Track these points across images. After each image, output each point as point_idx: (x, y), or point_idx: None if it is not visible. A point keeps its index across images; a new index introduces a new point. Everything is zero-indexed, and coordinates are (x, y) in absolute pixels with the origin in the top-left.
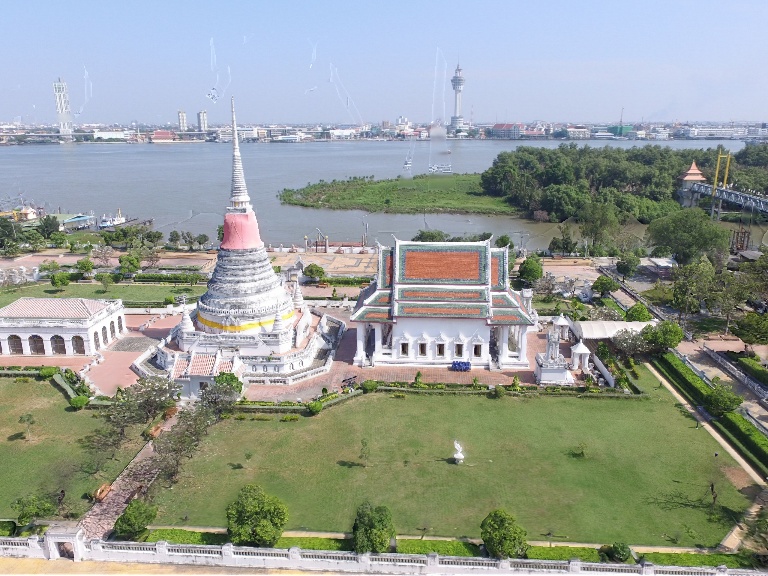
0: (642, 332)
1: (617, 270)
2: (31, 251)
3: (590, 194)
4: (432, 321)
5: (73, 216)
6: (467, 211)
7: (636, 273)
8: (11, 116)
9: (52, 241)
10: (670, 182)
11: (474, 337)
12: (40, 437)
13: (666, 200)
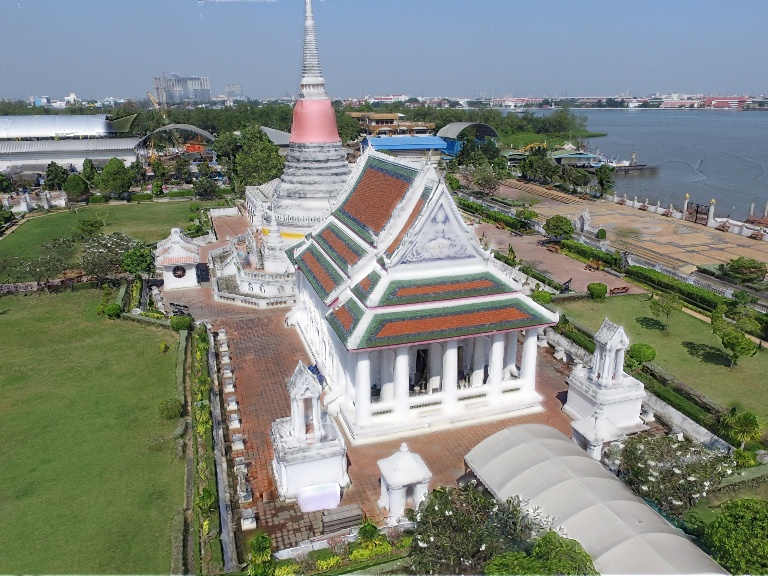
0: (533, 542)
1: None
2: None
3: None
4: None
5: (574, 152)
6: None
7: None
8: (197, 2)
9: (496, 165)
10: None
11: None
12: None
13: None
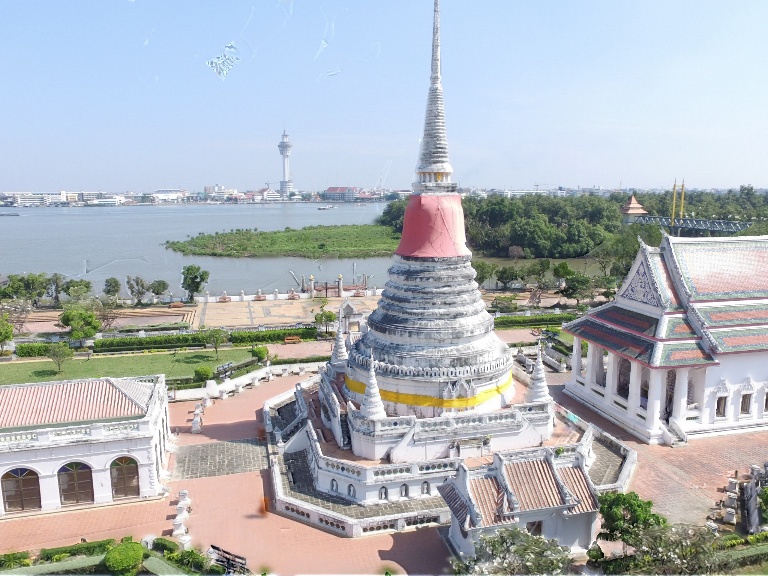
0: None
1: None
2: None
3: None
4: (760, 356)
5: None
6: None
7: None
8: None
9: None
10: None
11: None
12: None
13: None
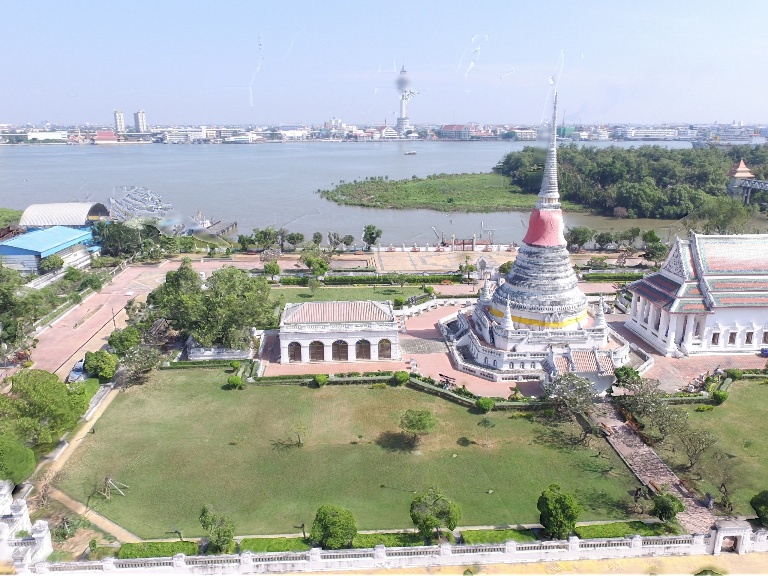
0: None
1: None
2: (165, 256)
3: (659, 191)
4: (744, 310)
5: None
6: None
7: None
8: None
9: (182, 245)
10: (725, 179)
11: None
12: (490, 441)
13: (721, 196)
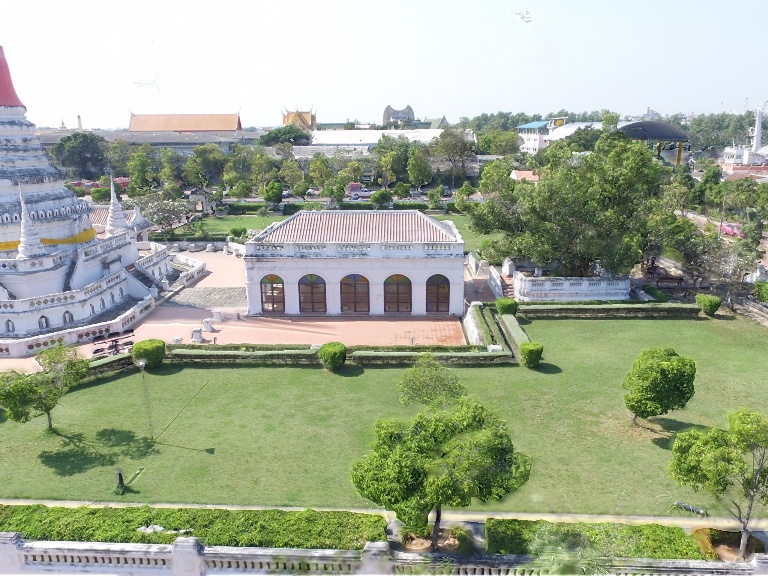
0: None
1: None
2: None
3: None
4: None
5: None
6: None
7: None
8: None
9: None
10: None
11: None
12: (259, 231)
13: None
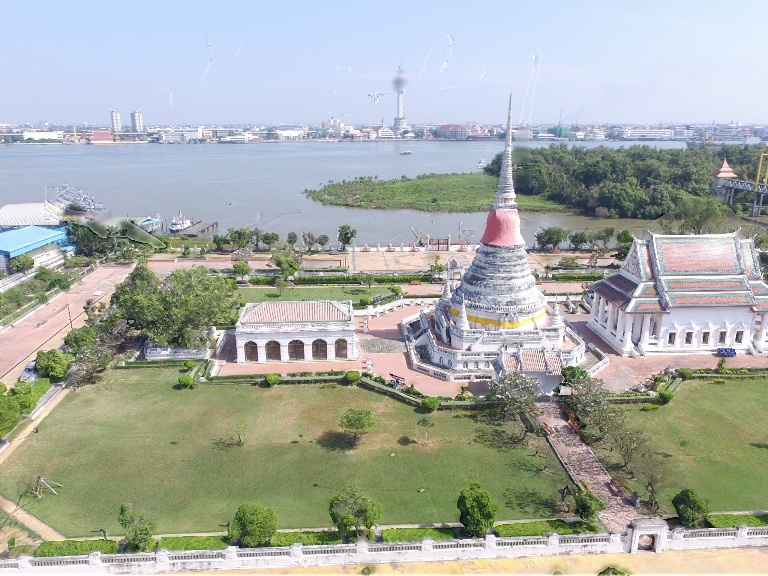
0: None
1: (761, 260)
2: None
3: (641, 191)
4: (700, 310)
5: (143, 219)
6: (519, 209)
7: (760, 263)
8: None
9: None
10: (708, 179)
11: (738, 324)
12: (431, 440)
13: None
